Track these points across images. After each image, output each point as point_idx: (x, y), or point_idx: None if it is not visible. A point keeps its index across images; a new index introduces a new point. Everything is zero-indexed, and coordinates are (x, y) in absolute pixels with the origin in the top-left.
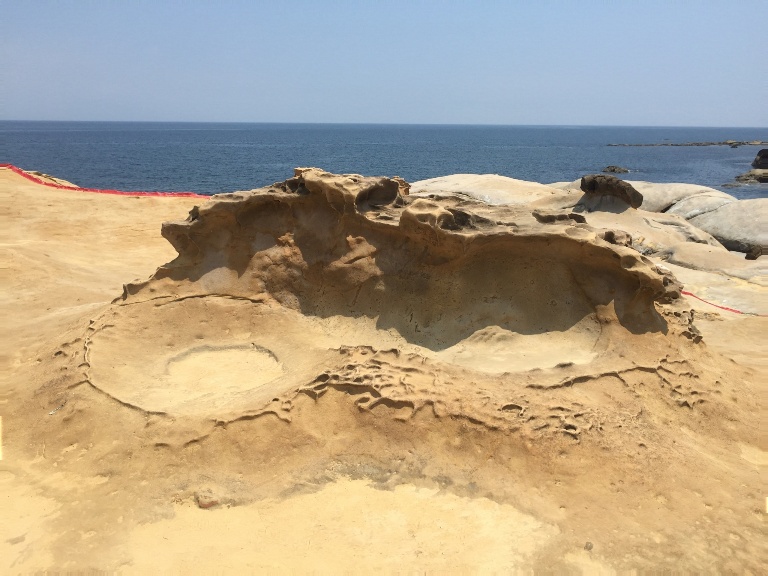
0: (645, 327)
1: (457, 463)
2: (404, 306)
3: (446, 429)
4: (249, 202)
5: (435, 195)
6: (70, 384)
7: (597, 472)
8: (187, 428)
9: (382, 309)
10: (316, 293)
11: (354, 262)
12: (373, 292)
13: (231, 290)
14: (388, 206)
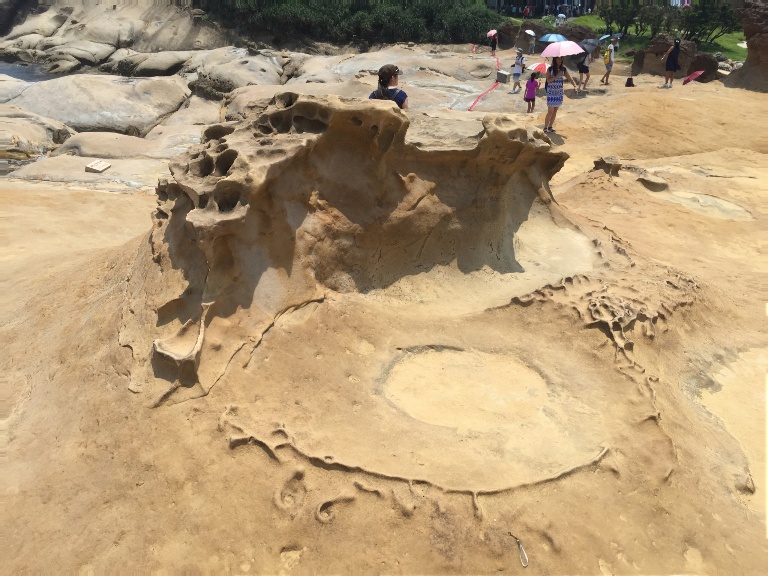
0: None
1: (704, 341)
2: (484, 238)
3: (678, 321)
4: None
5: None
6: (478, 514)
7: None
8: (646, 444)
9: (459, 250)
10: (371, 260)
11: (417, 206)
12: (446, 234)
13: (290, 298)
14: None
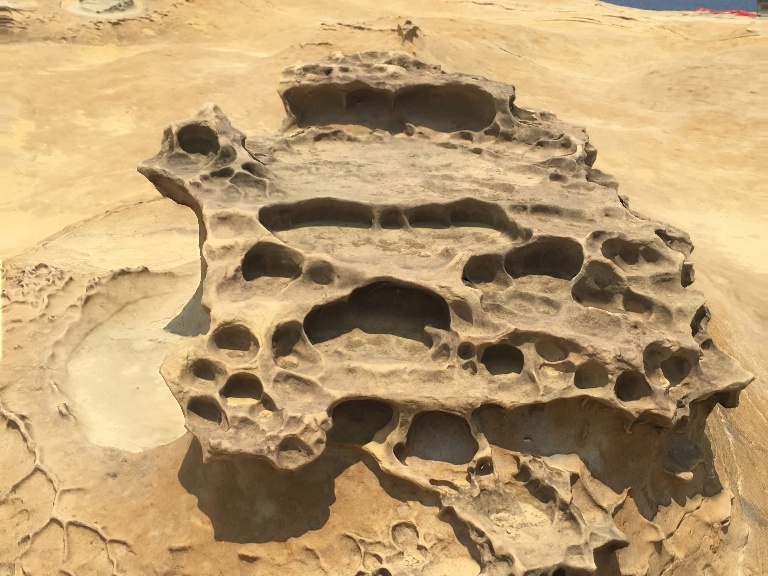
0: (202, 485)
1: None
2: None
3: None
4: None
5: (564, 136)
6: None
7: None
8: None
9: None
10: None
11: None
12: None
13: None
14: (454, 133)
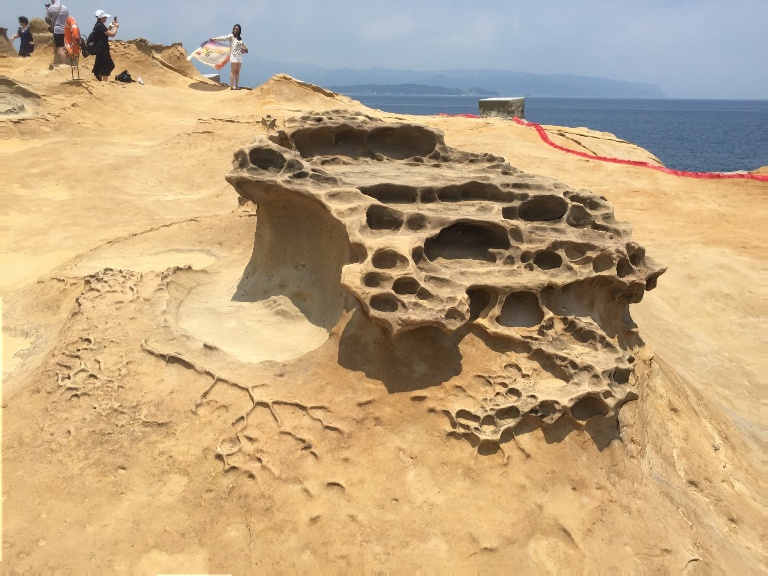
0: (365, 363)
1: None
2: None
3: None
4: (281, 137)
5: (488, 154)
6: None
7: (14, 419)
8: None
9: None
10: None
11: None
12: None
13: None
14: None
